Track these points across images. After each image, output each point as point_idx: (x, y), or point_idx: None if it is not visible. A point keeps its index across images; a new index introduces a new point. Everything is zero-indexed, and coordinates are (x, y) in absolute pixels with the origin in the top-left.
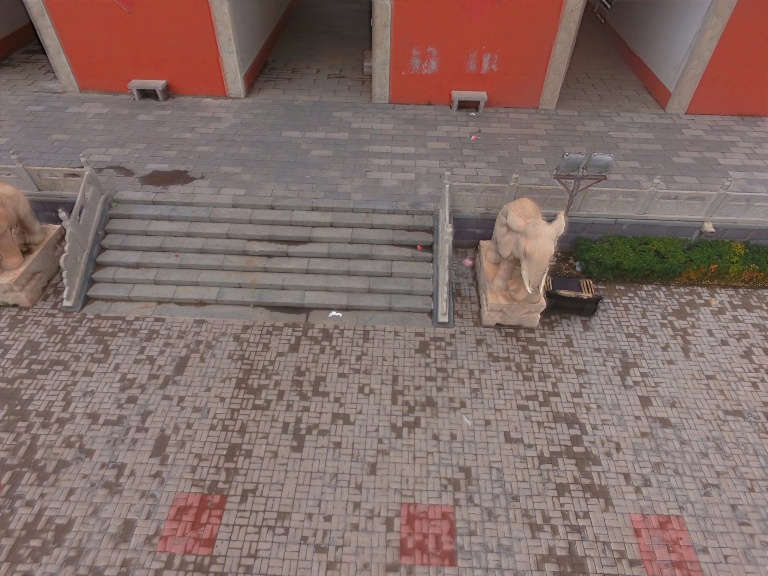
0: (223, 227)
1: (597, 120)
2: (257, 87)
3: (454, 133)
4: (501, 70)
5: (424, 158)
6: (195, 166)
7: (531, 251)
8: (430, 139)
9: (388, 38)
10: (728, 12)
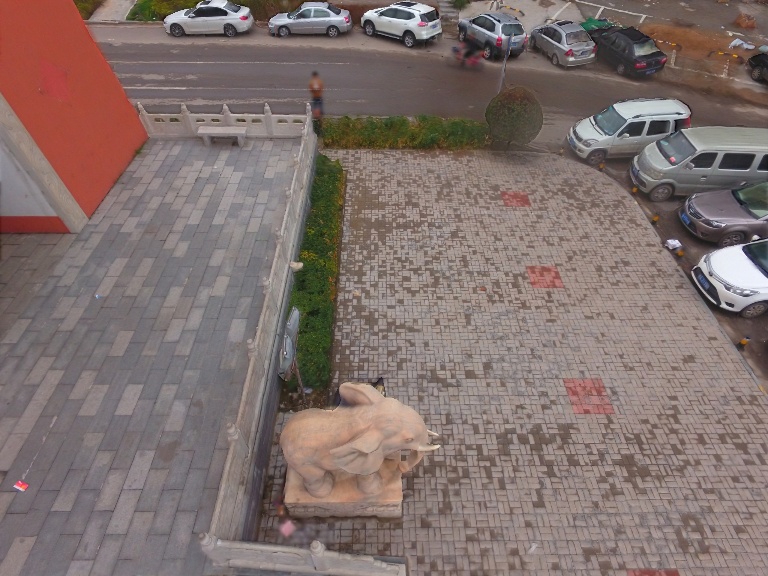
0: None
1: (57, 302)
2: None
3: None
4: None
5: None
6: None
7: (415, 432)
8: None
9: None
10: (14, 119)
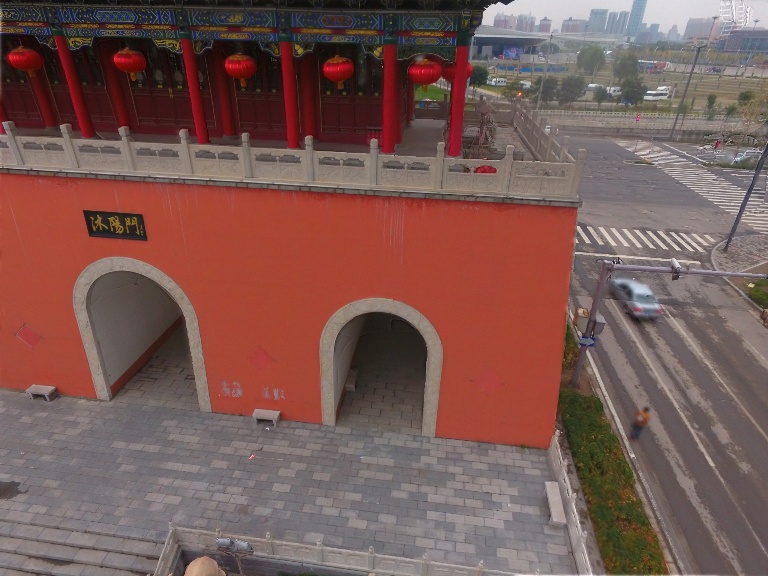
0: (16, 543)
1: (360, 441)
2: (127, 388)
3: (240, 451)
4: (289, 399)
5: (200, 479)
6: (29, 478)
7: None
8: (218, 457)
9: (205, 375)
10: (438, 379)
